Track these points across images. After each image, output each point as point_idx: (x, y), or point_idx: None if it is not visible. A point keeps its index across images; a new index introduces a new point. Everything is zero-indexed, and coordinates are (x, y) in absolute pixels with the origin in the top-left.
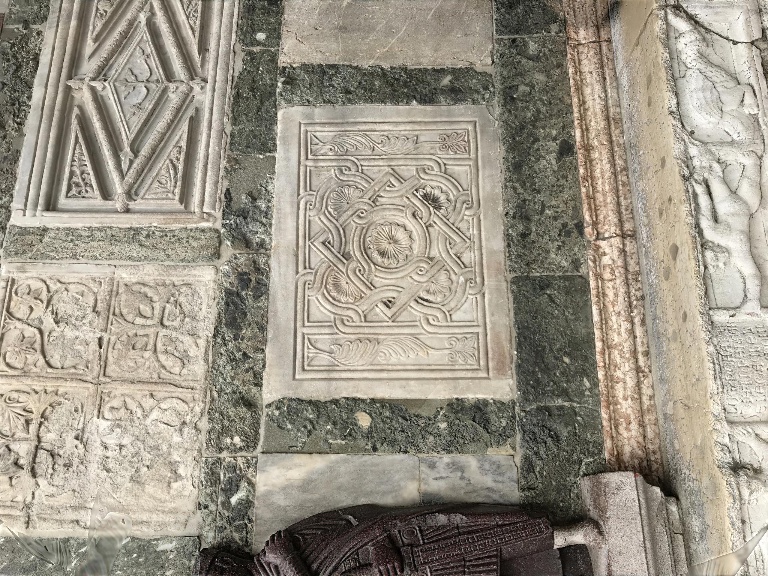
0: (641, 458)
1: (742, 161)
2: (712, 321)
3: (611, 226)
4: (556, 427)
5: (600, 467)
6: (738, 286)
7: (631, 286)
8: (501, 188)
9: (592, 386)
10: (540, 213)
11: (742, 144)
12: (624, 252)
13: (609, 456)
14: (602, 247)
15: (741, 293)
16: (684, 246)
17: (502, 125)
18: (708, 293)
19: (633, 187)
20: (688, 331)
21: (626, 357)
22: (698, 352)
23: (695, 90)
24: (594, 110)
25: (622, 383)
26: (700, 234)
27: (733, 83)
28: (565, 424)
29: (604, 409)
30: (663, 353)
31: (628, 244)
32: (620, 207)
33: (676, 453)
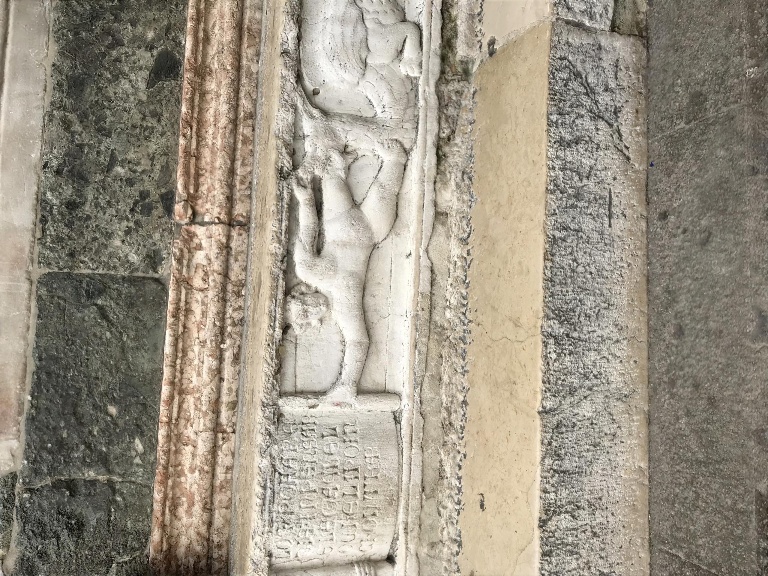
0: (198, 557)
1: (380, 154)
2: (282, 414)
3: (215, 205)
4: (81, 512)
5: (139, 569)
6: (334, 357)
7: (229, 303)
8: (41, 118)
9: (146, 451)
10: (106, 170)
11: (384, 126)
12: (227, 249)
13: (153, 555)
14: (198, 236)
15: (336, 368)
16: (263, 288)
17: (58, 4)
18: (285, 369)
19: (255, 148)
20: (252, 420)
21: (202, 410)
22: (252, 462)
23: (332, 18)
24: (221, 7)
25: (191, 447)
26: (291, 270)
27: (394, 17)
28: (94, 509)
29: (157, 487)
30: (242, 420)
31: (235, 237)
32: (234, 176)
33: (233, 566)
